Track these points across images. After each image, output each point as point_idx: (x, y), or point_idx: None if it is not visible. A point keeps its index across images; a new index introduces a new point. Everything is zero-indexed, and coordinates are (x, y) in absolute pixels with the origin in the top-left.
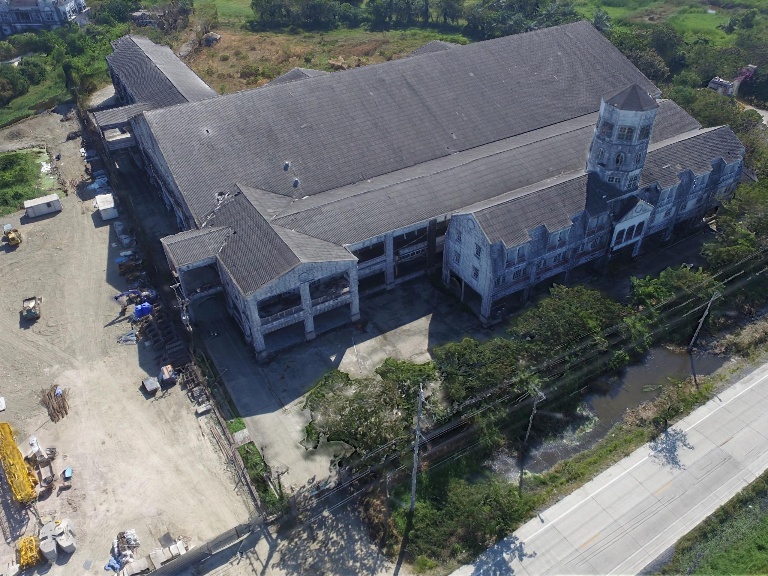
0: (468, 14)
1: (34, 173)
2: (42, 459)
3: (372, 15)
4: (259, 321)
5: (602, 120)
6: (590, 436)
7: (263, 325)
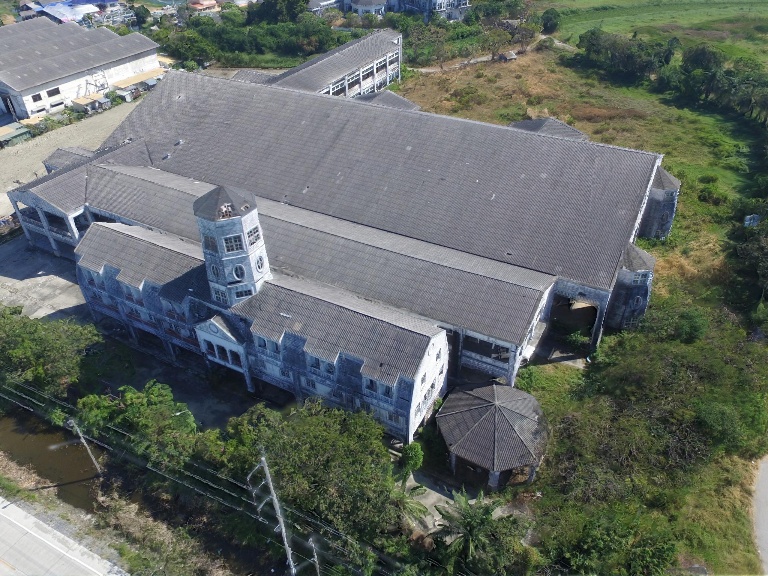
0: None
1: None
2: None
3: (682, 85)
4: (21, 216)
5: None
6: None
7: (24, 221)
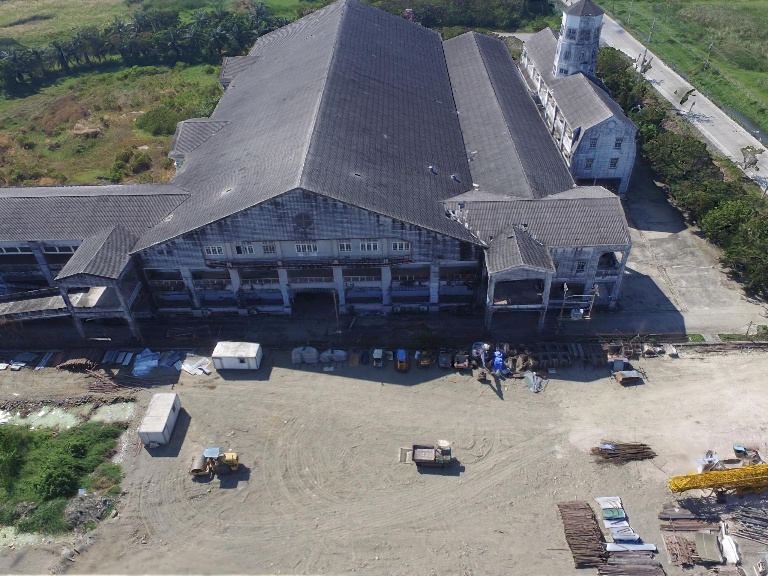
0: (118, 44)
1: (7, 429)
2: (720, 465)
3: (2, 80)
4: None
5: (580, 30)
6: None
7: None
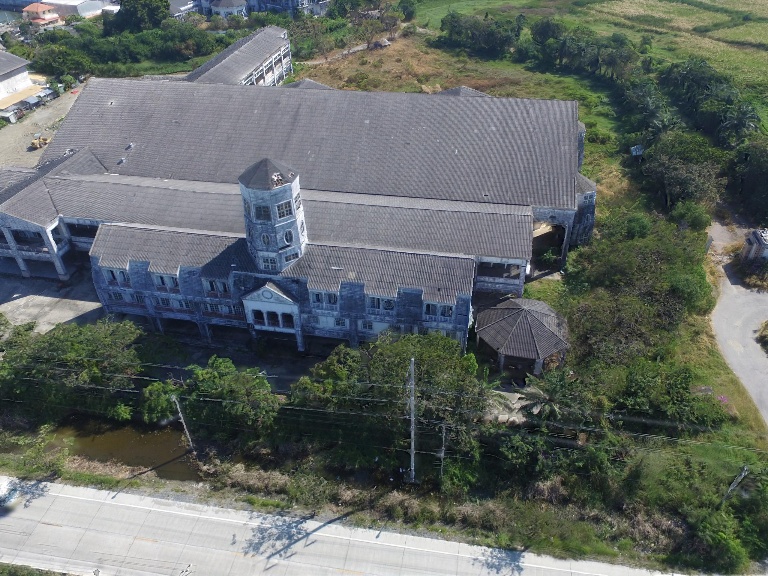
0: None
1: None
2: None
3: (539, 53)
4: None
5: None
6: (13, 446)
7: None
